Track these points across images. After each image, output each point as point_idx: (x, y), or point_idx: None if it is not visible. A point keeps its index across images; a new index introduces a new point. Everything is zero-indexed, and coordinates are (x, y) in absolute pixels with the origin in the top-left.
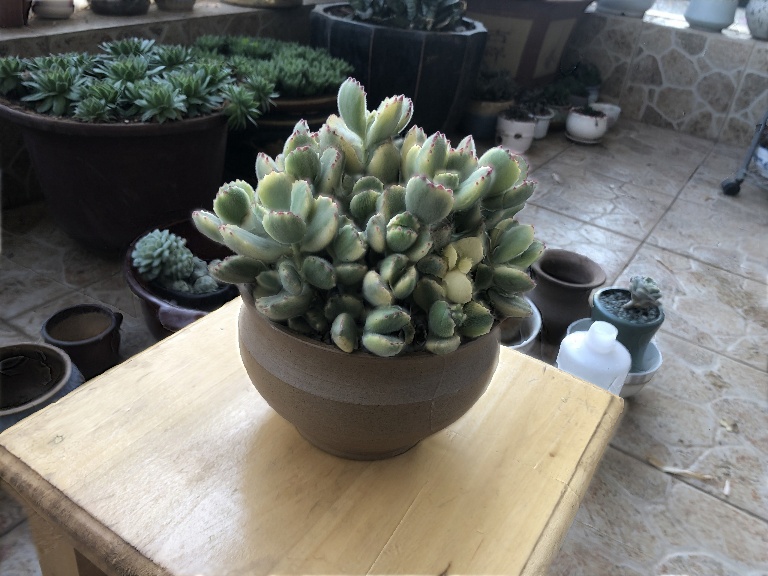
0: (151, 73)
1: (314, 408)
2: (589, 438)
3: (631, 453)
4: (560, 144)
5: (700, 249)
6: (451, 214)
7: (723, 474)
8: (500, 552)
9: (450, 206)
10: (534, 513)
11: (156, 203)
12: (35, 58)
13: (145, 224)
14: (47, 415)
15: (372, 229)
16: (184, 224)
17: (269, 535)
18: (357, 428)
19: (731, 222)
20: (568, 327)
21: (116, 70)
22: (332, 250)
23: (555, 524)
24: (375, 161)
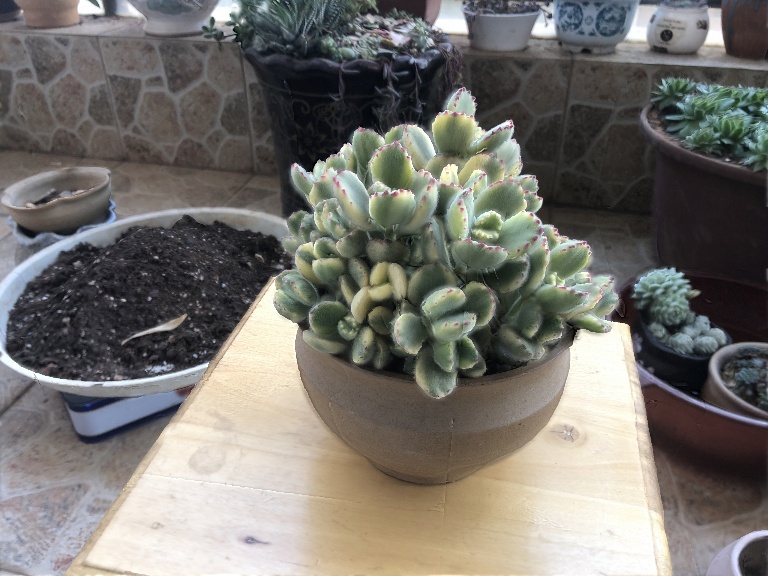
0: None
1: None
2: None
3: None
4: None
5: None
6: (407, 236)
7: None
8: None
9: (350, 209)
10: None
11: (727, 254)
12: (713, 85)
13: None
14: None
15: None
16: (731, 284)
17: (252, 417)
18: None
19: None
20: None
21: None
22: None
23: None
24: None
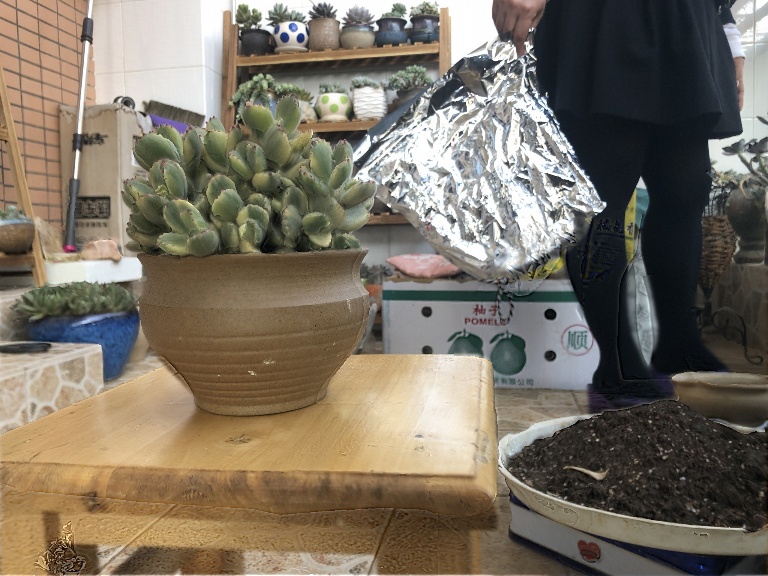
0: None
1: None
2: None
3: None
4: None
5: None
6: None
7: None
8: (139, 382)
9: None
10: None
11: None
12: None
13: None
14: None
15: None
16: None
17: None
18: None
19: None
20: None
21: None
22: None
23: None
24: None
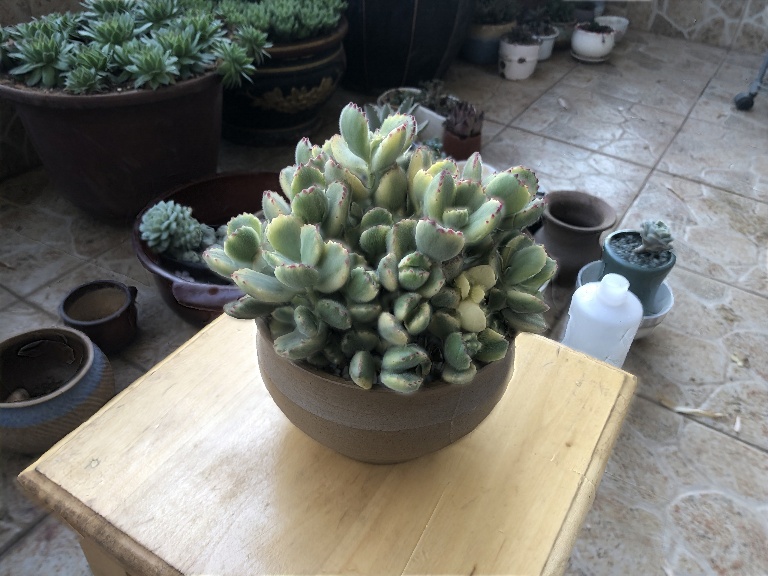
0: (138, 32)
1: (337, 434)
2: (604, 424)
3: (643, 395)
4: (566, 64)
5: (712, 173)
6: None
7: (734, 411)
8: (522, 551)
9: (461, 246)
10: (553, 508)
11: (157, 169)
12: (17, 25)
13: (149, 191)
14: (81, 438)
15: (384, 272)
16: (188, 189)
17: (303, 549)
18: (380, 449)
19: (744, 140)
20: (579, 272)
21: (102, 32)
22: (345, 291)
23: (573, 517)
24: (382, 189)
